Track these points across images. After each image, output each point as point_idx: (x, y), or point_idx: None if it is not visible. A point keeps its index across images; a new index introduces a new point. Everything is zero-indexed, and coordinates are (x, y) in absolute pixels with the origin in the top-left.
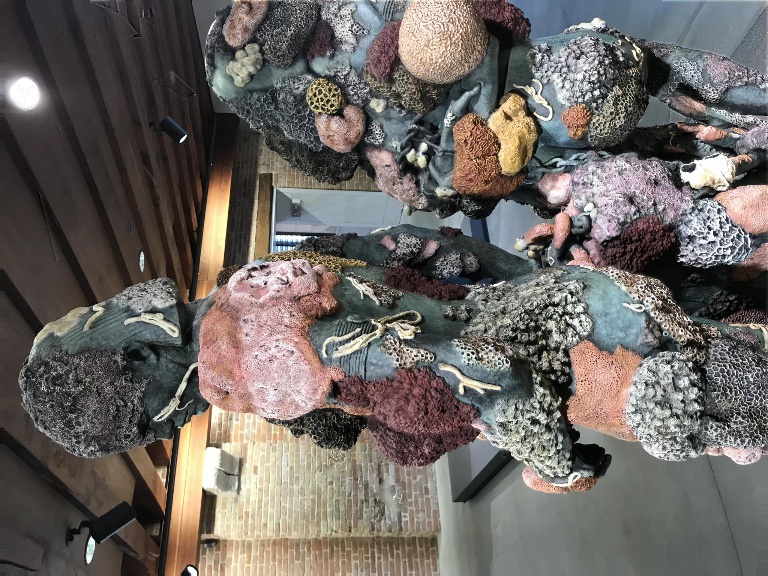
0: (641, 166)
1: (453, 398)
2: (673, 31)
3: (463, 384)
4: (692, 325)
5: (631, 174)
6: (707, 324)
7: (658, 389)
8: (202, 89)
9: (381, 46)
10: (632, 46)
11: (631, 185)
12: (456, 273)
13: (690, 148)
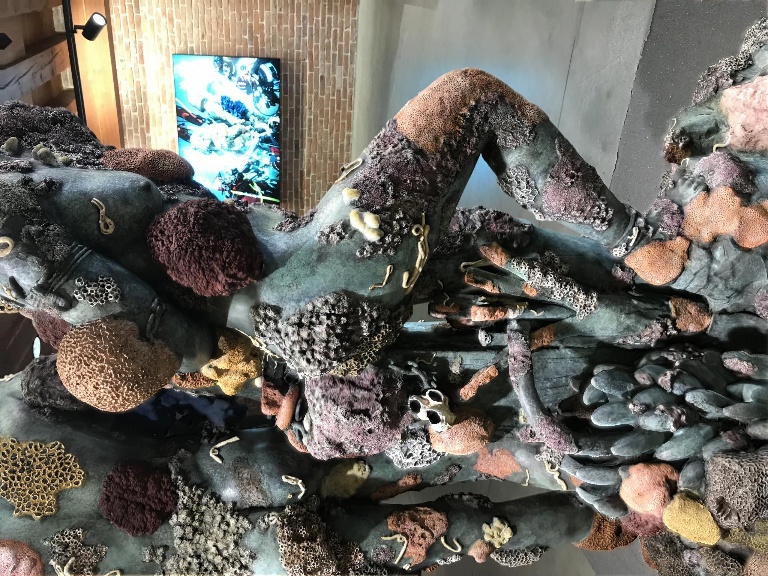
0: (359, 420)
1: None
2: None
3: None
4: (335, 573)
5: (346, 427)
6: (362, 542)
7: None
8: None
9: (44, 337)
10: (416, 247)
11: (342, 435)
12: (194, 396)
13: (467, 304)
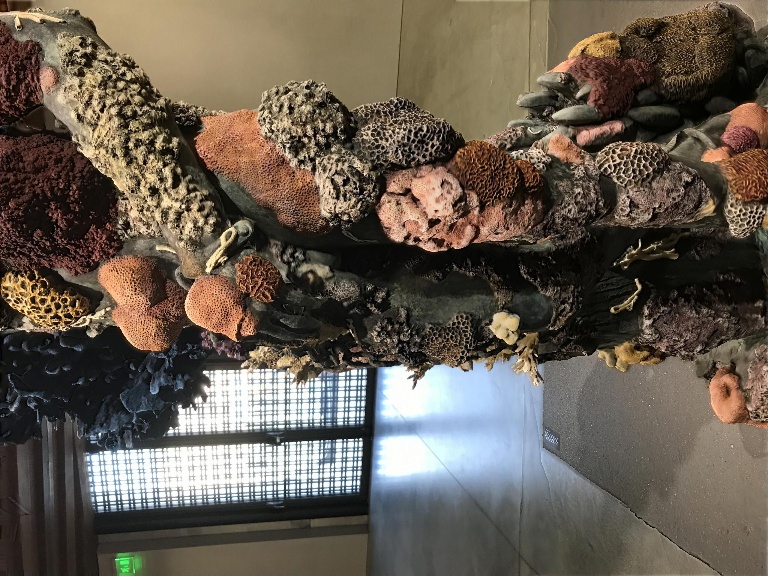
0: None
1: (10, 39)
2: (516, 404)
3: (18, 15)
4: None
5: None
6: None
7: (280, 87)
8: (39, 512)
9: None
10: None
11: None
12: None
13: None
